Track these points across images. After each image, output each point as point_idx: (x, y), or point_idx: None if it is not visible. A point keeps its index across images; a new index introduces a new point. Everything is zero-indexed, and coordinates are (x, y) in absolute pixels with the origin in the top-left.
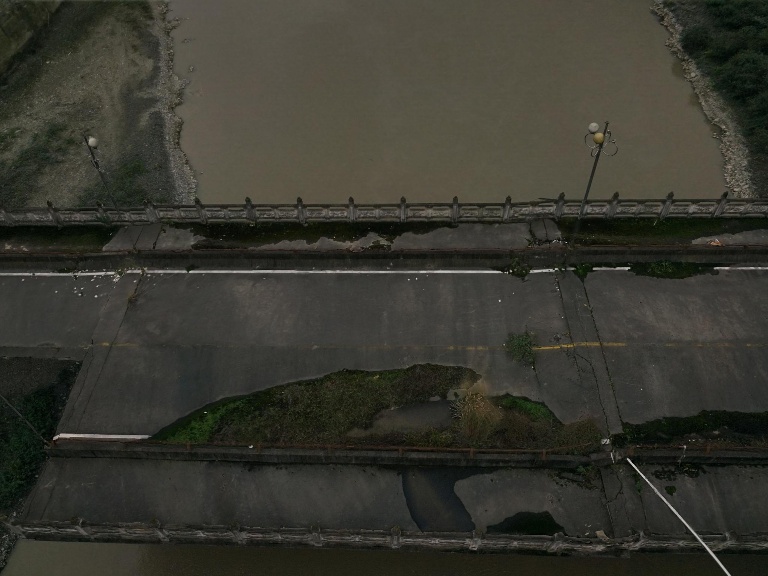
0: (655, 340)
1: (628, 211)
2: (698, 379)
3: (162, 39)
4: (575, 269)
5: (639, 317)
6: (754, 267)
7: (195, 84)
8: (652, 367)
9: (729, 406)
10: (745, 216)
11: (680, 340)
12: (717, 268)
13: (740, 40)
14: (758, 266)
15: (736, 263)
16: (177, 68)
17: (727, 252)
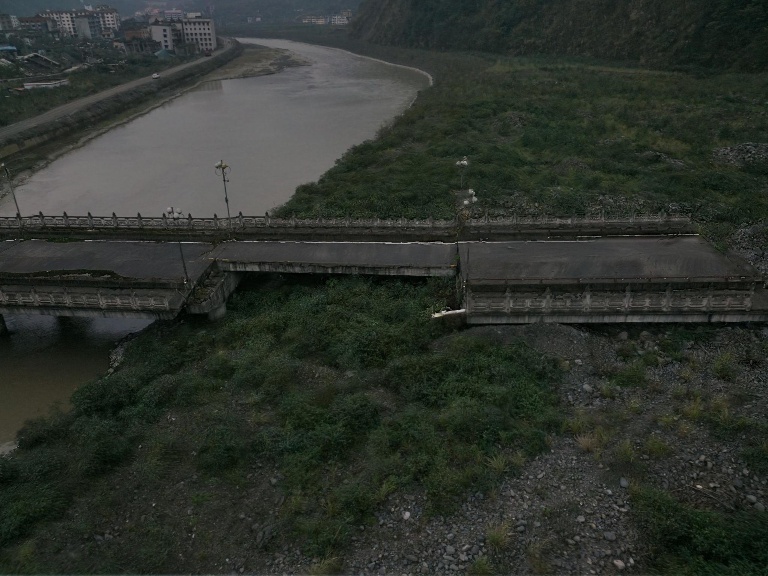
0: (18, 256)
1: (75, 223)
2: (15, 265)
3: (7, 188)
4: (23, 239)
5: (23, 251)
6: (103, 240)
7: (3, 207)
8: (2, 262)
9: (14, 271)
10: (131, 227)
11: (28, 256)
12: (86, 240)
13: (304, 188)
14: (106, 240)
15: (98, 239)
16: (1, 200)
17: (93, 234)
